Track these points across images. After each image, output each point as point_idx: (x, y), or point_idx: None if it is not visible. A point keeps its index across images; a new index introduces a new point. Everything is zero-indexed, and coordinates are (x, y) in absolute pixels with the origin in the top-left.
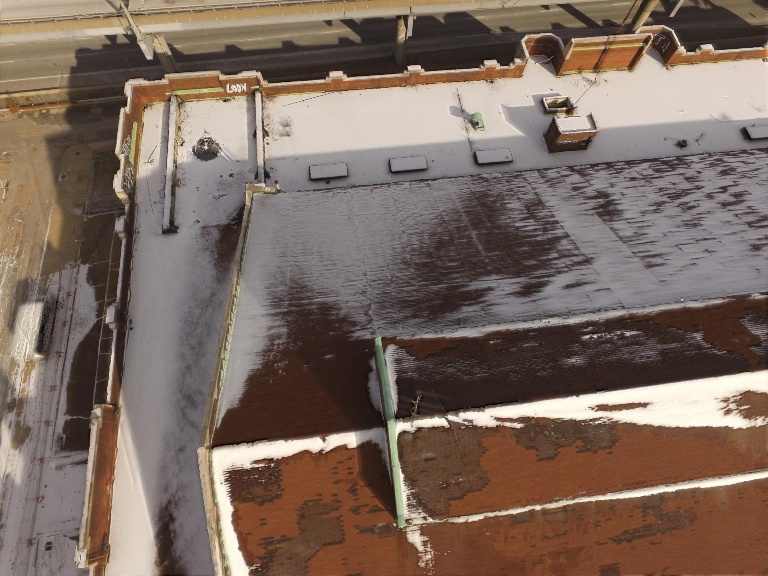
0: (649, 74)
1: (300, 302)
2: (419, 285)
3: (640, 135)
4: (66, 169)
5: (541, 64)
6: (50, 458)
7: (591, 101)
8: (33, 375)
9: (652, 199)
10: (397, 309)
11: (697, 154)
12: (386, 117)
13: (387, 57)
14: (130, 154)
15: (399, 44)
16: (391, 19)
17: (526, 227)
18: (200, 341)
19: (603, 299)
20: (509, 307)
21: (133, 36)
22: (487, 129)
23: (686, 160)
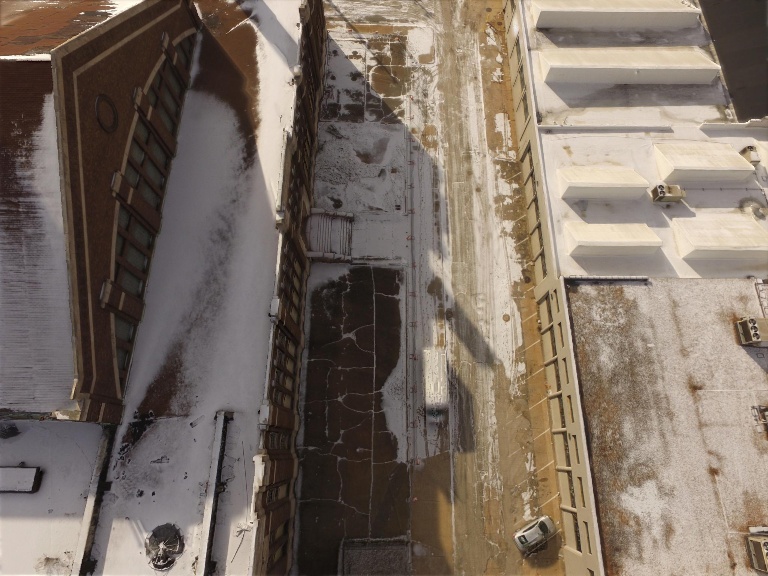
0: None
1: (8, 208)
2: None
3: None
4: None
5: None
6: (406, 266)
7: None
8: (435, 340)
9: None
10: None
11: None
12: None
13: None
14: None
15: None
16: None
17: None
18: (208, 286)
19: None
20: None
21: None
22: None
23: None
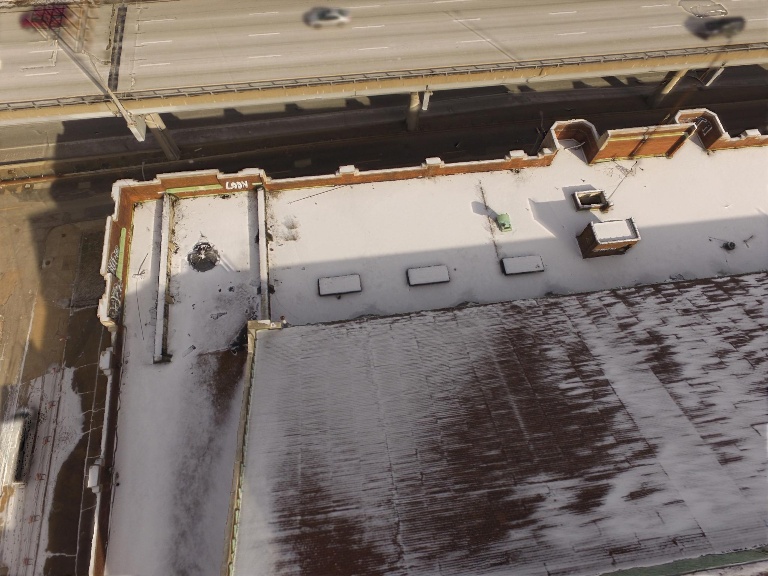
0: (689, 161)
1: (314, 517)
2: (455, 490)
3: (682, 235)
4: (51, 254)
5: (571, 150)
6: None
7: (627, 194)
8: (11, 502)
9: (713, 346)
10: (431, 532)
11: (753, 273)
12: (402, 216)
13: (398, 122)
14: (118, 268)
15: (412, 112)
16: (405, 95)
17: (572, 391)
18: (196, 500)
19: (677, 521)
20: (566, 532)
21: (123, 118)
22: (514, 229)
23: (742, 282)
